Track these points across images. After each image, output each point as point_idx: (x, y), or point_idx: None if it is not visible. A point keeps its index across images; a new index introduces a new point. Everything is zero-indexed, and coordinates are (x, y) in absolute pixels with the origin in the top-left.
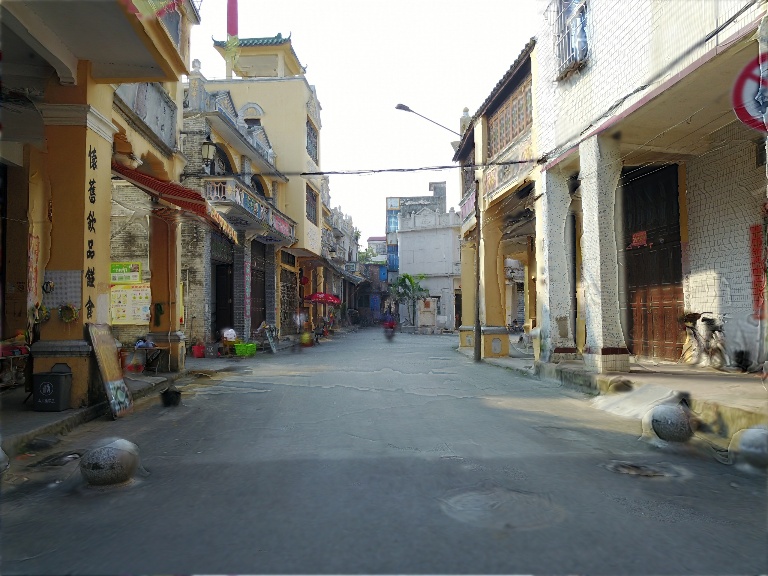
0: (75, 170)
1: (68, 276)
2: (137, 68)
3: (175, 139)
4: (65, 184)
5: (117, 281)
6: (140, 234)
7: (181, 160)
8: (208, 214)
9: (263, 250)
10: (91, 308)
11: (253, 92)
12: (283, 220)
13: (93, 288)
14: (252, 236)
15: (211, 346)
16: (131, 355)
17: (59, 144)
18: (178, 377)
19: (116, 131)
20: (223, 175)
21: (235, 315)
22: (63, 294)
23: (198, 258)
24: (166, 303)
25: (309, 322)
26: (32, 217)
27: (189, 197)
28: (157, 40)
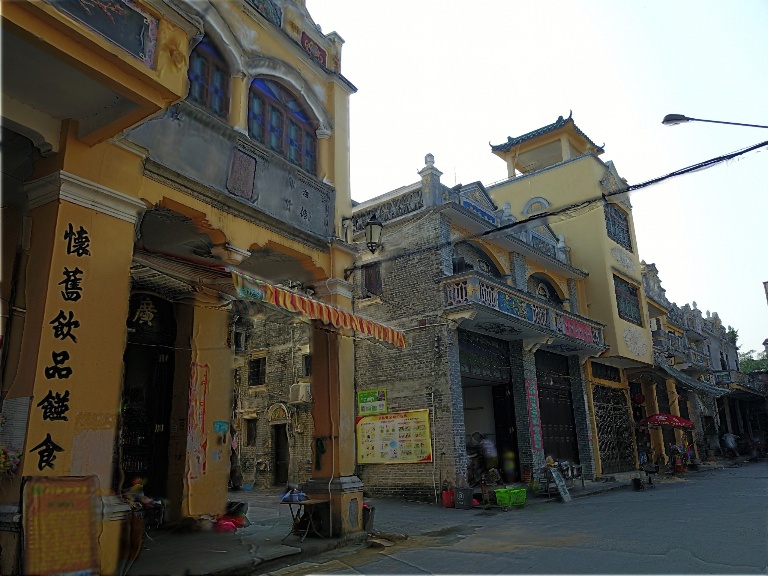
0: (42, 258)
1: (18, 406)
2: (114, 108)
3: (333, 227)
4: (33, 279)
5: (365, 412)
6: (384, 356)
7: (344, 251)
8: (249, 297)
9: (564, 363)
10: (53, 452)
11: (535, 186)
12: (579, 322)
13: (63, 422)
14: (533, 346)
15: (461, 492)
16: (372, 502)
17: (35, 230)
18: (336, 546)
19: (140, 206)
20: (461, 273)
21: (520, 448)
22: (11, 433)
23: (442, 378)
24: (327, 438)
25: (660, 454)
26: (198, 344)
27: (218, 275)
28: (50, 36)
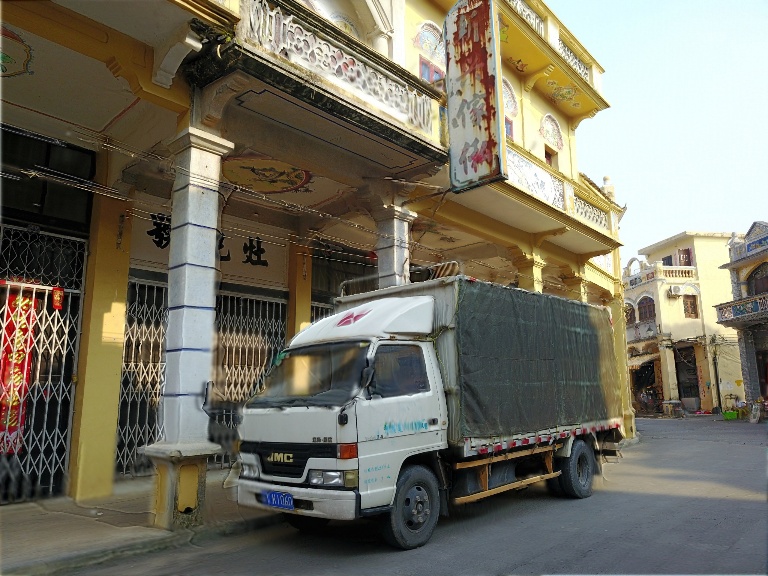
0: None
1: None
2: None
3: None
4: None
5: None
6: None
7: None
8: None
9: None
10: None
11: None
12: None
13: None
14: None
15: None
16: None
17: None
18: None
19: None
20: None
21: None
22: None
23: None
24: None
25: None
26: (697, 360)
27: None
28: None
